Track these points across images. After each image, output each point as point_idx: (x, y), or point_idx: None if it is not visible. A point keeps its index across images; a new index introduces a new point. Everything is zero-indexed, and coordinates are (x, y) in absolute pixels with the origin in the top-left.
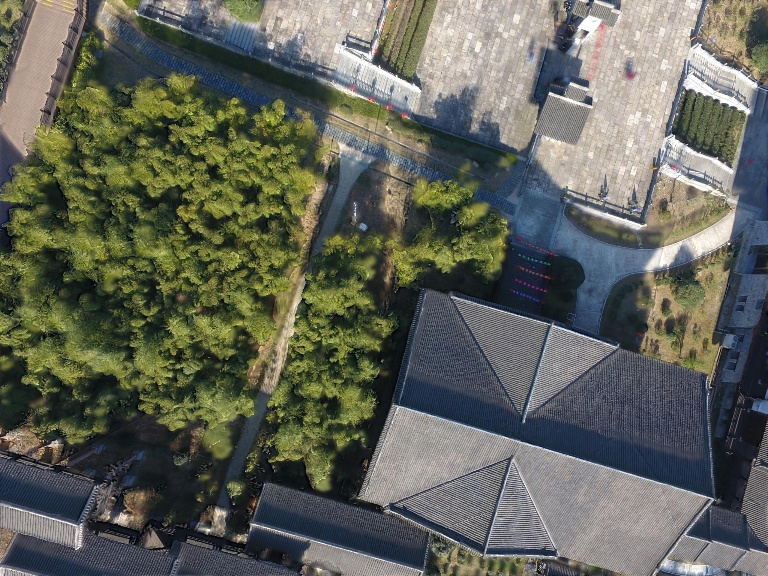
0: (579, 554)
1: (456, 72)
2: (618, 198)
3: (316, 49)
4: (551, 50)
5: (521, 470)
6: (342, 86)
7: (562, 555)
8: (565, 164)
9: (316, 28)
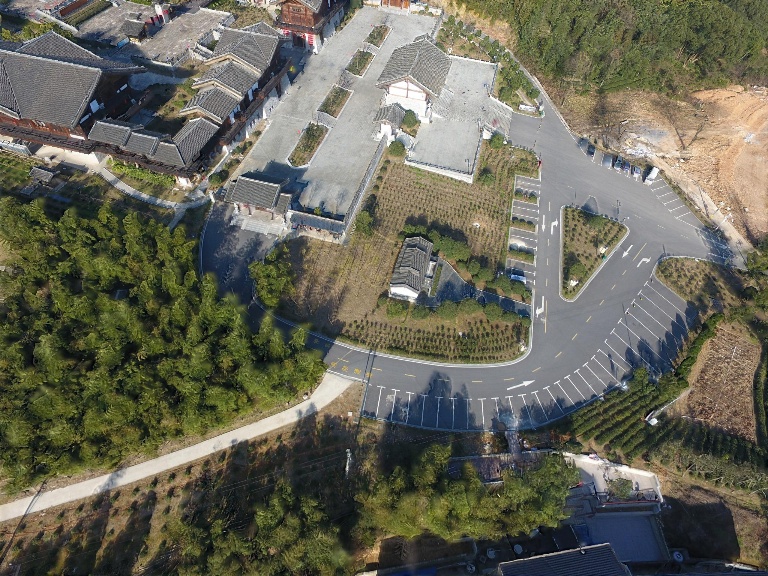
0: (33, 114)
1: (99, 28)
2: (163, 59)
3: (26, 11)
4: (149, 25)
5: (7, 68)
6: (31, 18)
7: (23, 116)
8: (140, 50)
9: (31, 7)
